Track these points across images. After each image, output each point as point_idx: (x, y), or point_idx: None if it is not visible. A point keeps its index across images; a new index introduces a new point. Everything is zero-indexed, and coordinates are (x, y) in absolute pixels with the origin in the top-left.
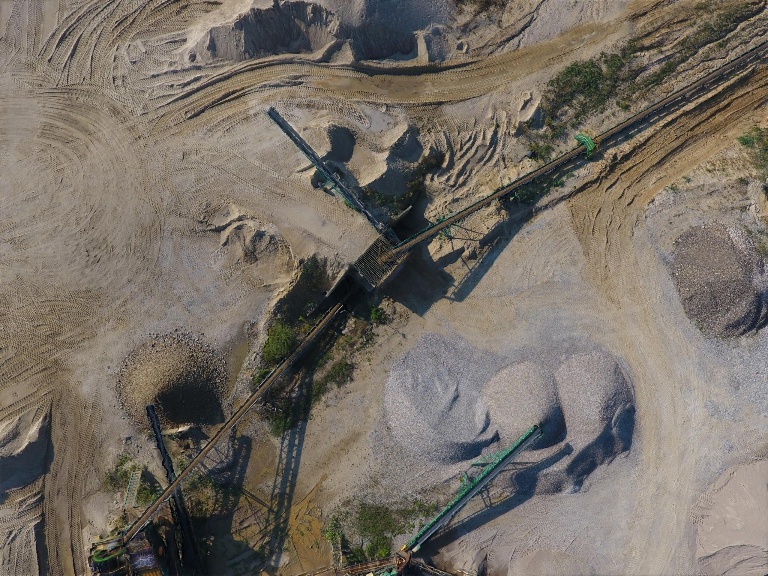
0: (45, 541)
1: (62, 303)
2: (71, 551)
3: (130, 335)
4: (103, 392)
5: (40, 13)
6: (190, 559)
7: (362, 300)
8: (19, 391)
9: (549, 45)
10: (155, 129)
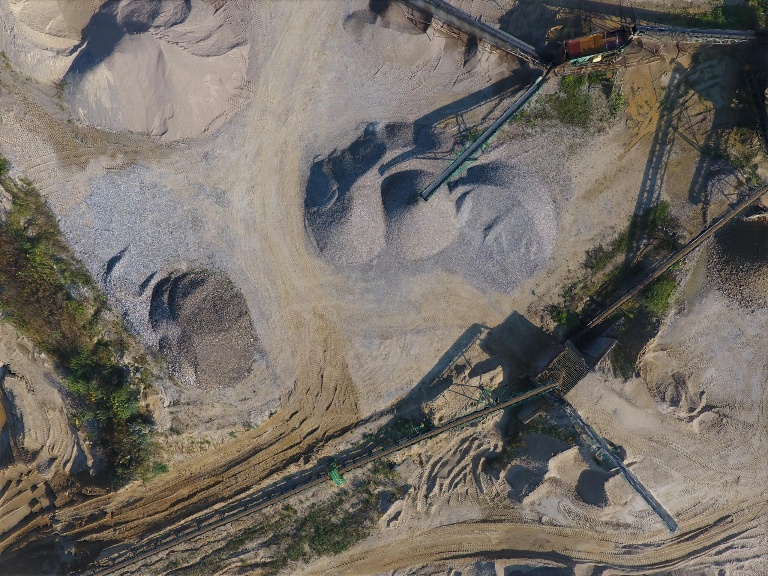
0: None
1: None
2: None
3: None
4: None
5: None
6: None
7: None
8: None
9: (362, 572)
10: (762, 507)
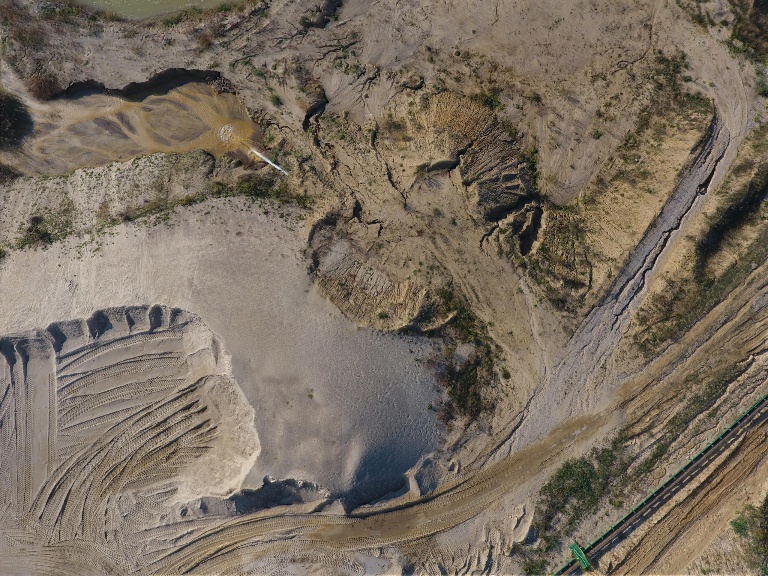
0: None
1: None
2: None
3: None
4: None
5: (29, 465)
6: None
7: None
8: None
9: (540, 447)
10: None
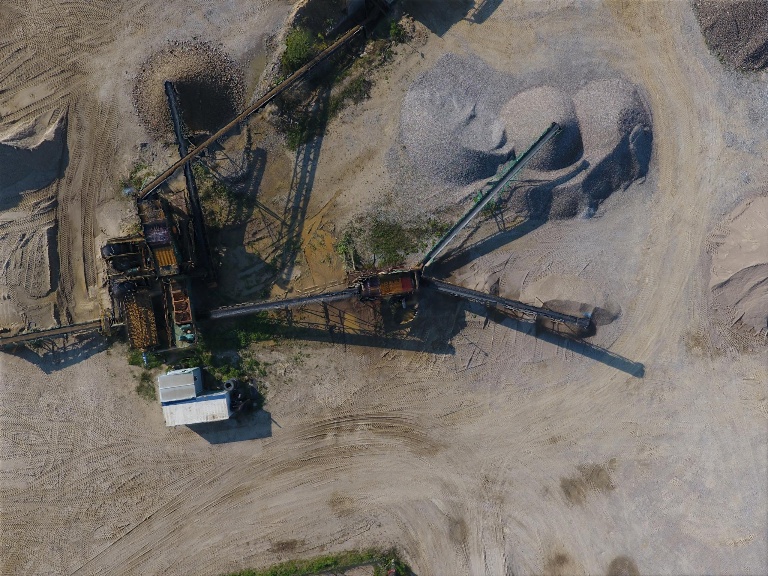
0: (57, 249)
1: (82, 5)
2: (83, 260)
3: (149, 41)
4: (120, 97)
5: None
6: (202, 261)
7: (381, 21)
8: (36, 93)
9: None
10: None
